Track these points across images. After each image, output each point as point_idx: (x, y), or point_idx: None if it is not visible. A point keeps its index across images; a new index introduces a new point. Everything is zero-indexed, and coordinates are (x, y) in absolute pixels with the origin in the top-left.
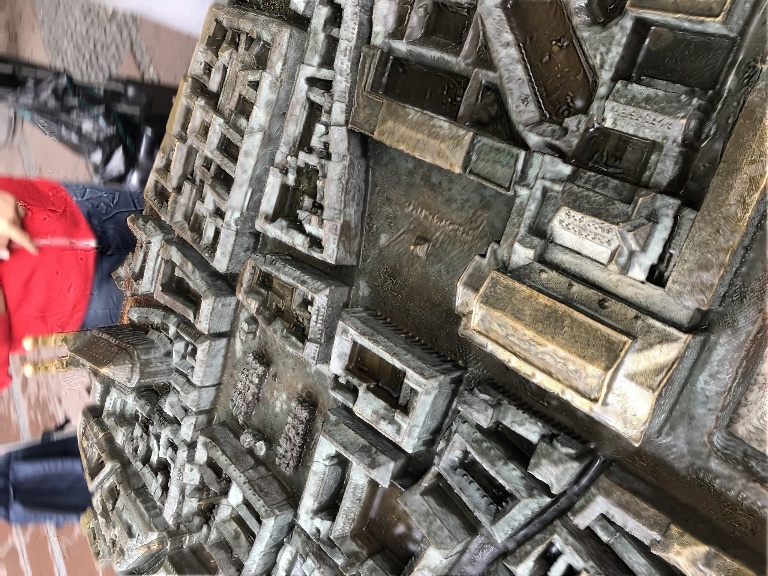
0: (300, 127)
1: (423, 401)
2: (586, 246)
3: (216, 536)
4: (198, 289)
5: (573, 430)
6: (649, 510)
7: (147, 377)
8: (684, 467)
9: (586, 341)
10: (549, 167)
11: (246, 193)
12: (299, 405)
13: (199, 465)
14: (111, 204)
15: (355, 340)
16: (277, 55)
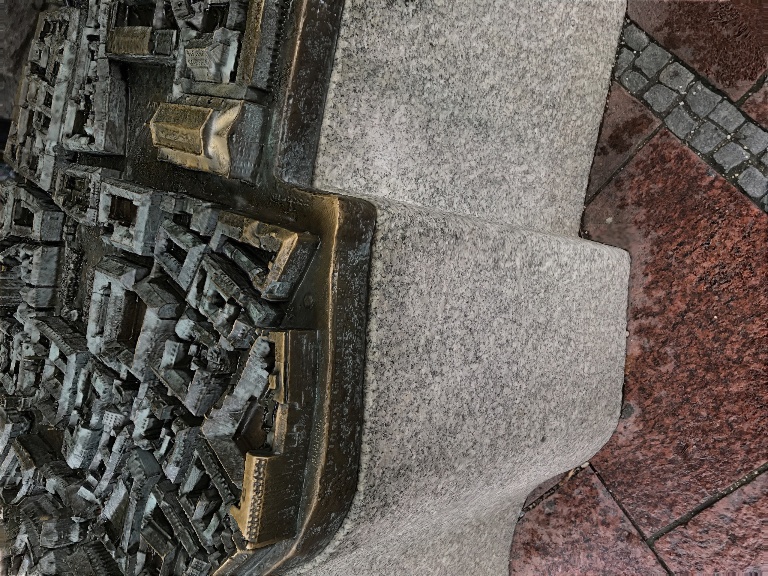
0: (87, 70)
1: (141, 211)
2: (206, 75)
3: (44, 395)
4: (34, 209)
5: (223, 203)
6: (238, 217)
7: (3, 294)
8: (268, 197)
9: (195, 119)
10: (185, 34)
11: (60, 128)
12: (94, 268)
13: (34, 344)
14: (2, 199)
15: (112, 193)
16: (72, 27)
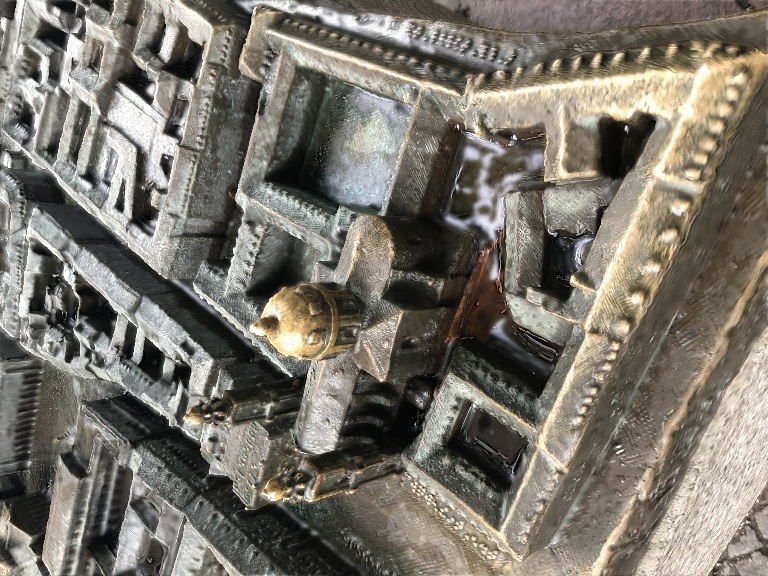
0: None
1: None
2: None
3: None
4: None
5: None
6: None
7: None
8: None
9: None
10: None
11: None
12: None
13: None
14: None
15: None
16: None
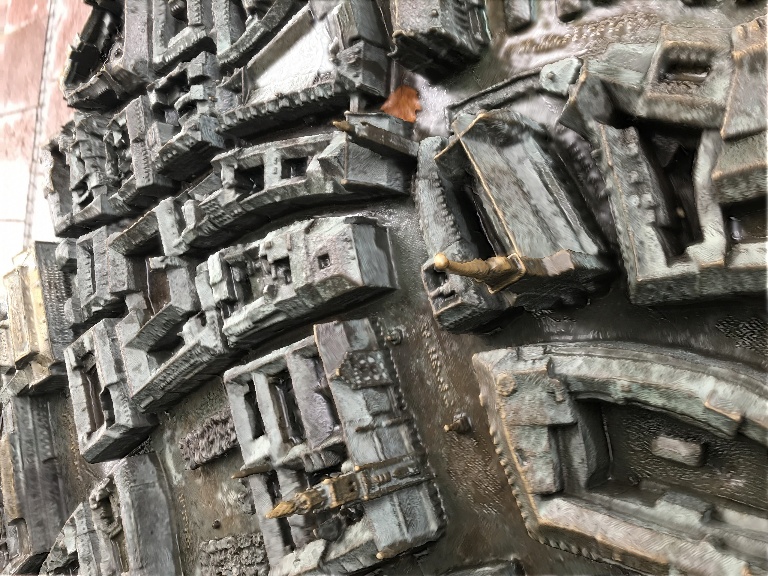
0: None
1: None
2: None
3: None
4: None
5: None
6: None
7: None
8: None
9: None
10: None
11: None
12: None
13: None
14: None
15: (89, 431)
16: None
